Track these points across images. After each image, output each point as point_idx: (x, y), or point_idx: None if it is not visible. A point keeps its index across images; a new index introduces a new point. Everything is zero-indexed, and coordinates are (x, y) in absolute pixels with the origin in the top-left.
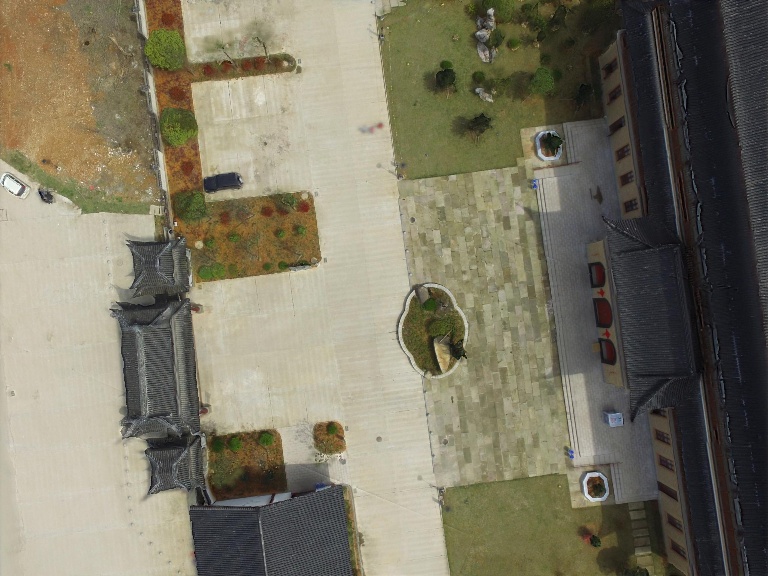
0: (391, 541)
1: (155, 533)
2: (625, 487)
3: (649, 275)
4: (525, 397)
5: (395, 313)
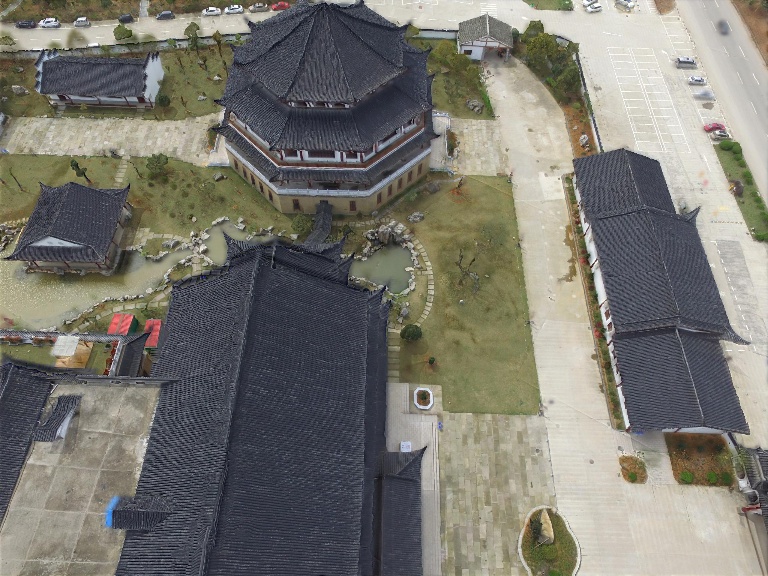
0: (579, 384)
1: (763, 417)
2: (401, 395)
3: (400, 570)
4: (471, 477)
5: (583, 574)
